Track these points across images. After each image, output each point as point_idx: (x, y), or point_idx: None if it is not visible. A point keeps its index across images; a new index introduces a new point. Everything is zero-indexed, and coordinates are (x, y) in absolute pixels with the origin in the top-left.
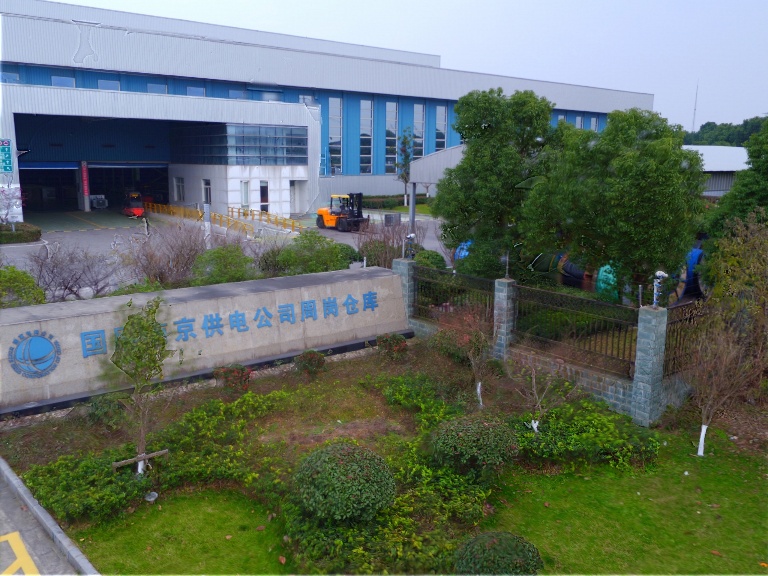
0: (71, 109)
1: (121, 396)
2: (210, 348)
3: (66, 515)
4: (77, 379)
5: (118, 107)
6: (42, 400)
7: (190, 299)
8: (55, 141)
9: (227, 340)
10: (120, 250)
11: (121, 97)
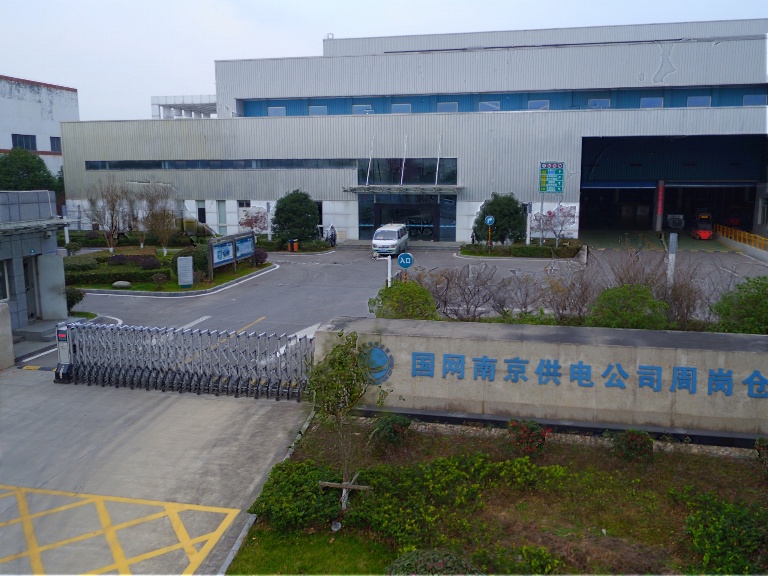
0: (636, 130)
1: (398, 421)
2: (542, 396)
3: (254, 511)
4: (403, 394)
5: (686, 124)
6: (372, 405)
7: (531, 339)
8: (635, 161)
9: (564, 392)
10: (556, 276)
11: (691, 113)
